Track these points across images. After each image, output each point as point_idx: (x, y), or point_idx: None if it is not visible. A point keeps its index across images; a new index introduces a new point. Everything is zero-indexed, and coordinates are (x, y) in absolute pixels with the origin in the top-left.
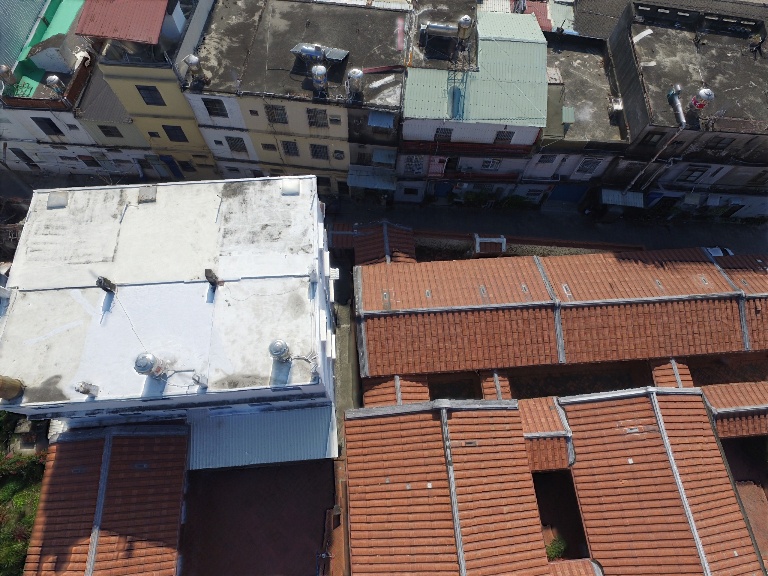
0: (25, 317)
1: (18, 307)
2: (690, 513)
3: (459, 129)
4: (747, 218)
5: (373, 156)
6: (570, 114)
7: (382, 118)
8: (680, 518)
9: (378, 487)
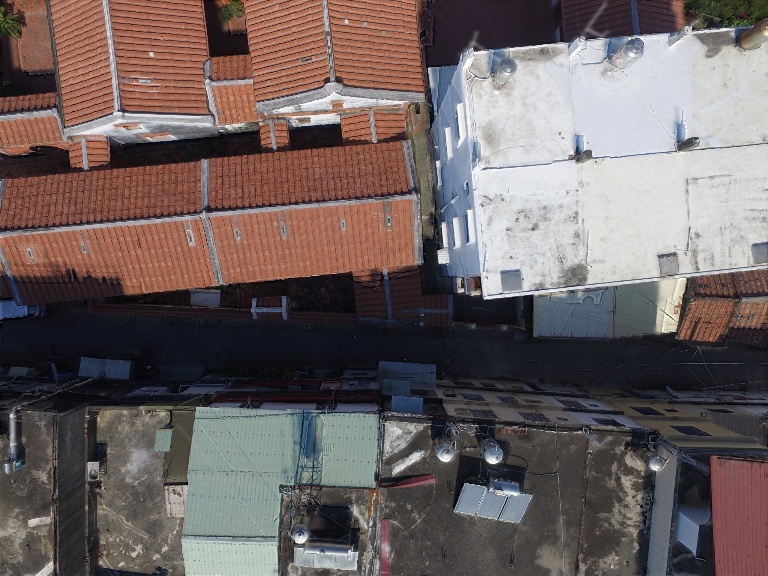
0: (757, 116)
1: (767, 126)
2: (104, 2)
3: None
4: None
5: None
6: (161, 441)
7: (406, 408)
8: None
9: (392, 29)
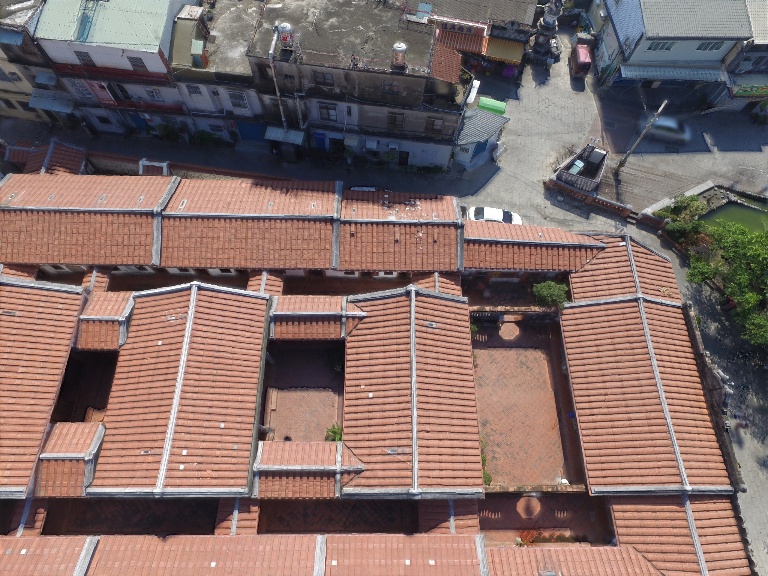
0: None
1: None
2: (179, 384)
3: (93, 53)
4: (423, 167)
5: (36, 77)
6: (198, 46)
7: (11, 36)
8: (171, 388)
9: None
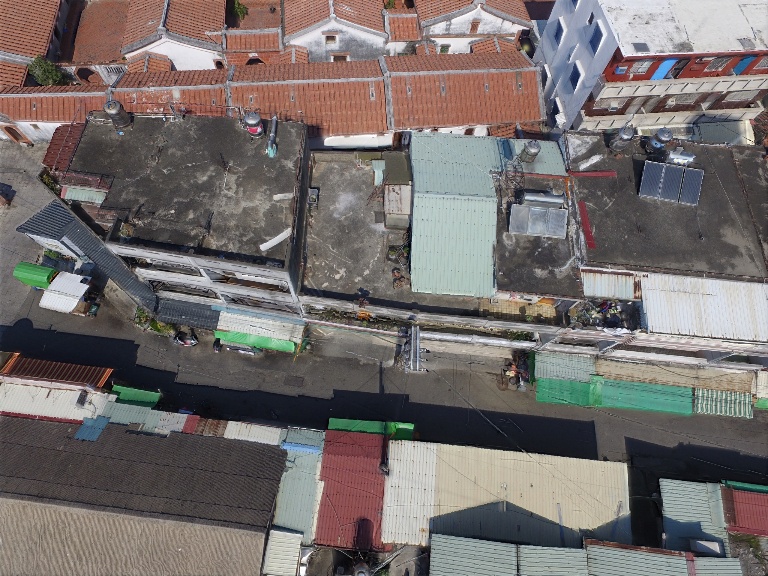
0: None
1: None
2: None
3: None
4: None
5: None
6: (377, 165)
7: None
8: None
9: None
